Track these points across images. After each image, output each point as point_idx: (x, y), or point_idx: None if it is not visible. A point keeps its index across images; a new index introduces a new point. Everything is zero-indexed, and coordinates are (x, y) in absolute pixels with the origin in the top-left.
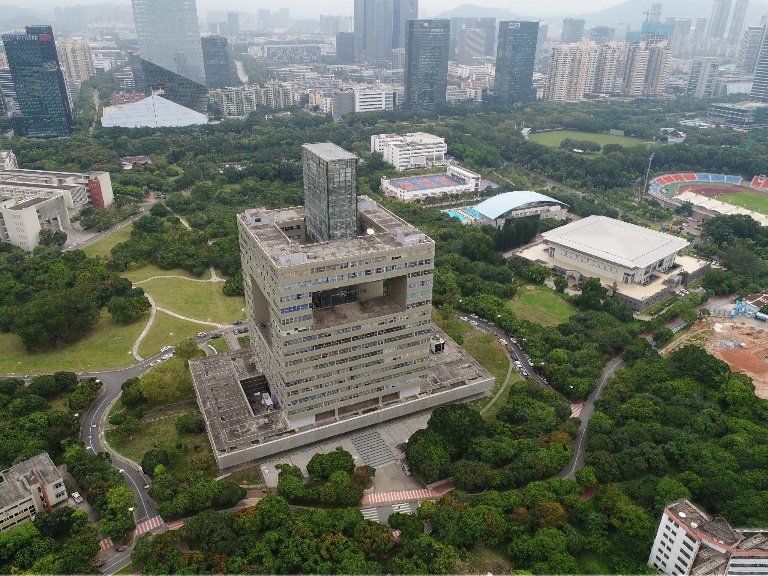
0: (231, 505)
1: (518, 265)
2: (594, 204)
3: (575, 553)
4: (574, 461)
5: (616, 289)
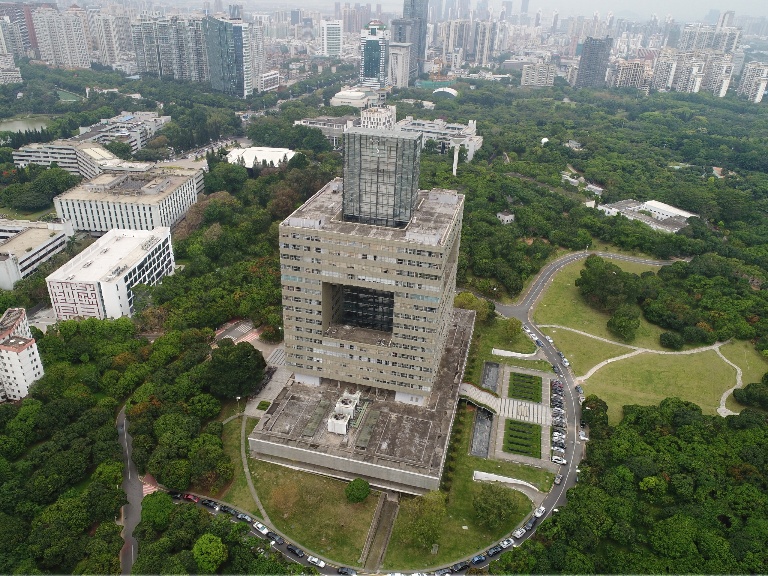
0: None
1: None
2: None
3: None
4: None
5: None
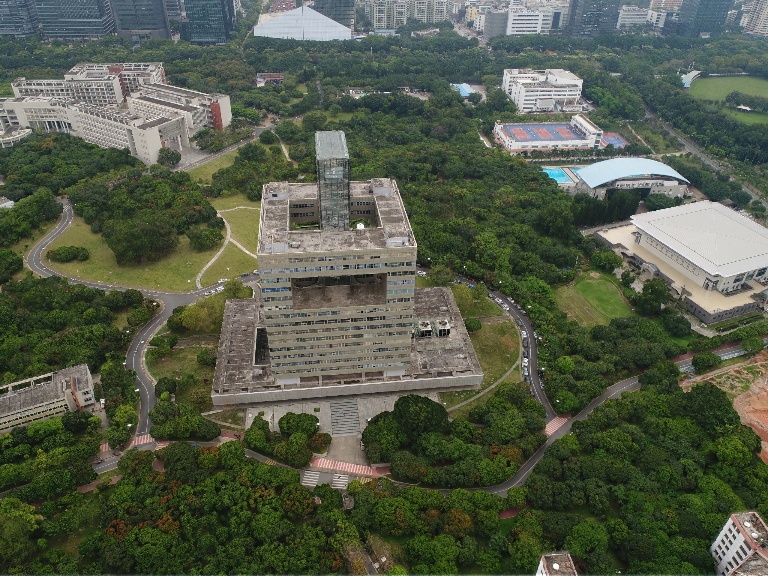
0: (208, 439)
1: (590, 248)
2: None
3: (464, 564)
4: (520, 476)
5: (689, 294)
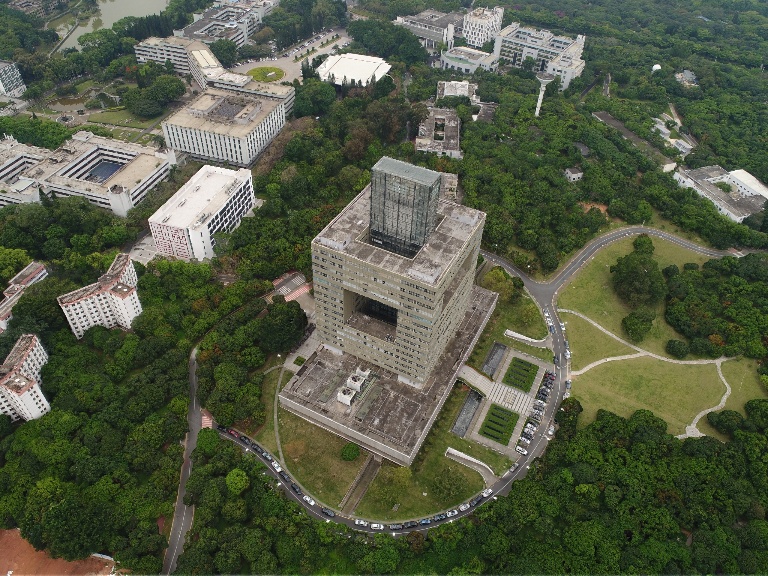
0: None
1: None
2: None
3: None
4: None
5: None
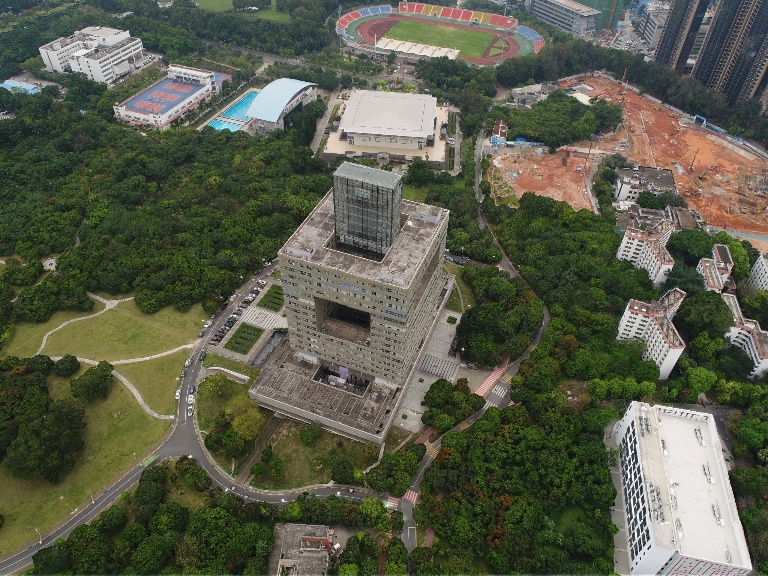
0: None
1: None
2: (328, 74)
3: None
4: None
5: (421, 158)
